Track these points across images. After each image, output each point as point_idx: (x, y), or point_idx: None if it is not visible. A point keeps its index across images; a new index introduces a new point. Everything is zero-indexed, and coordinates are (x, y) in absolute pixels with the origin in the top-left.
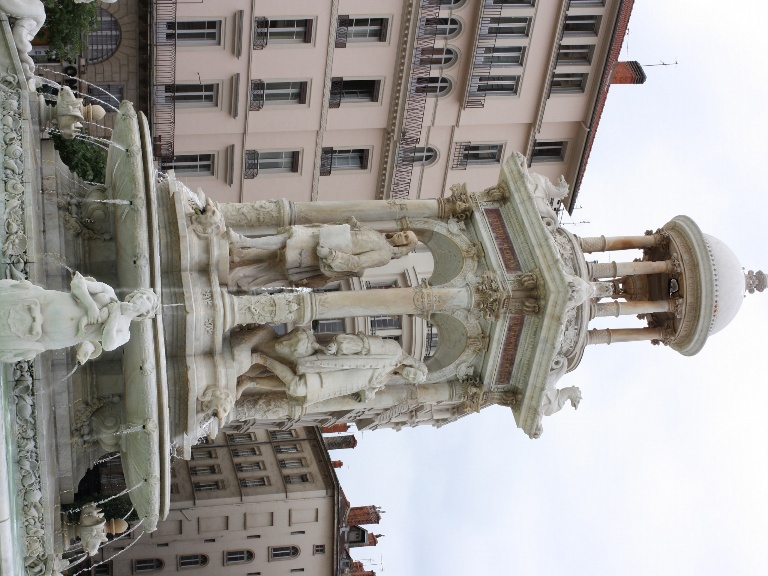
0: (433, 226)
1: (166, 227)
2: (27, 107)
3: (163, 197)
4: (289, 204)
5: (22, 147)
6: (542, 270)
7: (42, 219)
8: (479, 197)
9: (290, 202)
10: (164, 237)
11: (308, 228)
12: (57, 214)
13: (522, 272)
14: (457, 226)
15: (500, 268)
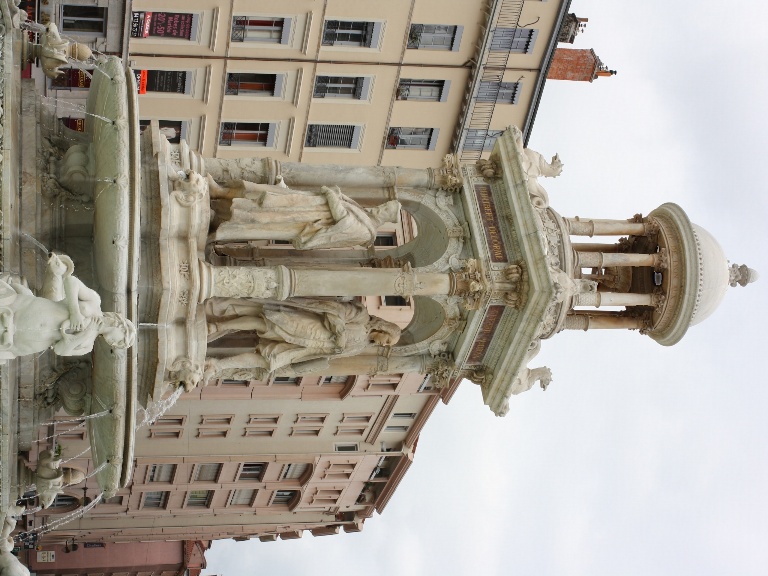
0: (434, 295)
1: (143, 376)
2: (7, 423)
3: (152, 304)
4: (288, 295)
5: (1, 459)
6: (492, 386)
7: (17, 423)
8: (494, 295)
9: (291, 292)
10: (139, 382)
11: (289, 354)
12: (32, 417)
13: (481, 363)
14: (457, 300)
15: (463, 359)
